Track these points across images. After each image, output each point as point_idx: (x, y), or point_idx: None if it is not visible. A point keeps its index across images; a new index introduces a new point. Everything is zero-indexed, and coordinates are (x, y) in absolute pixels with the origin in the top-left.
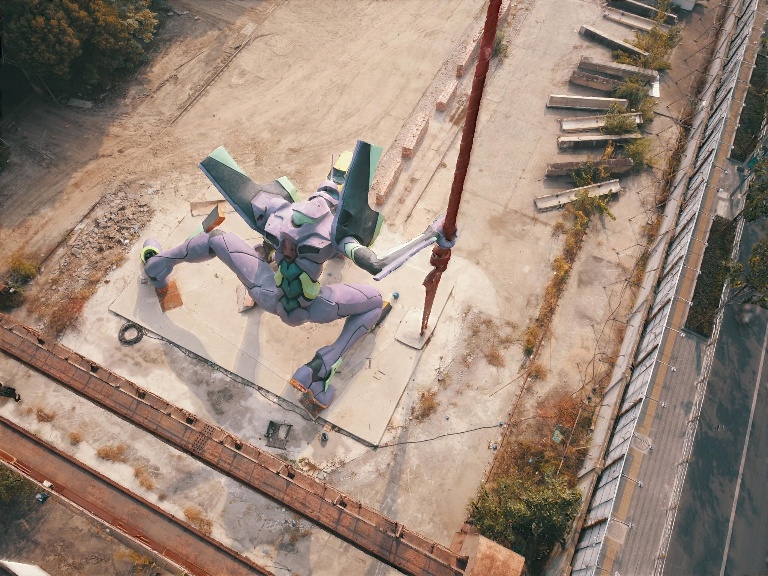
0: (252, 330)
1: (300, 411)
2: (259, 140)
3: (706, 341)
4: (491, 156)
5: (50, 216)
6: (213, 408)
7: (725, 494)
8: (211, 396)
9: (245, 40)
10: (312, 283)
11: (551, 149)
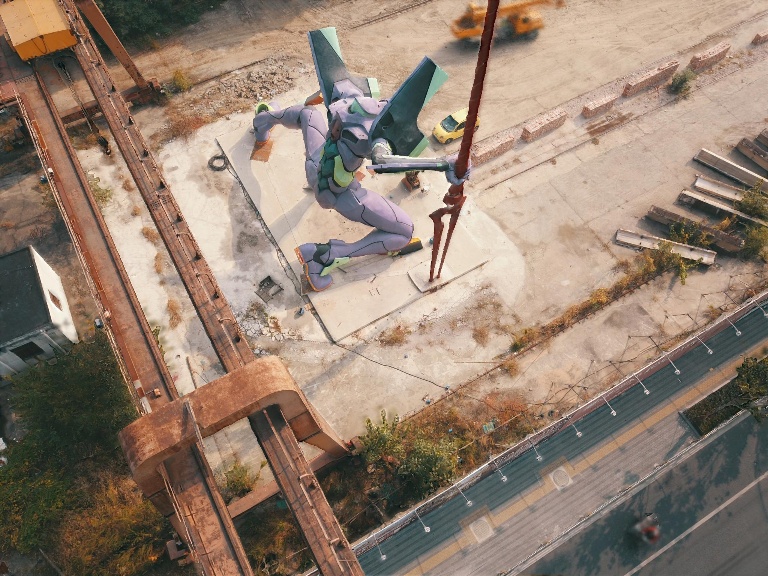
0: (303, 206)
1: (297, 283)
2: (410, 71)
3: (697, 437)
4: (604, 175)
5: (222, 55)
6: (237, 245)
7: (610, 571)
8: (242, 236)
9: None
10: (344, 170)
11: (669, 197)
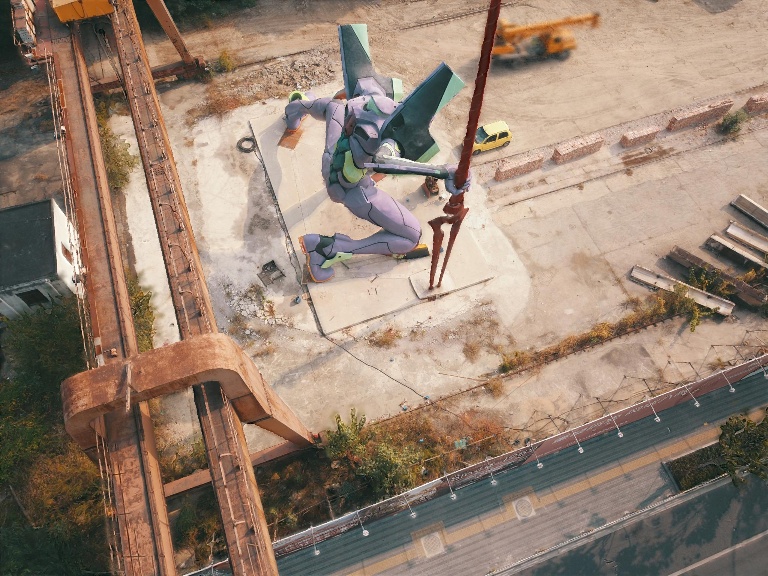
0: (320, 197)
1: (299, 271)
2: None
3: (676, 491)
4: (631, 208)
5: (271, 41)
6: (250, 226)
7: None
8: (256, 218)
9: (512, 1)
10: (354, 166)
11: (696, 239)
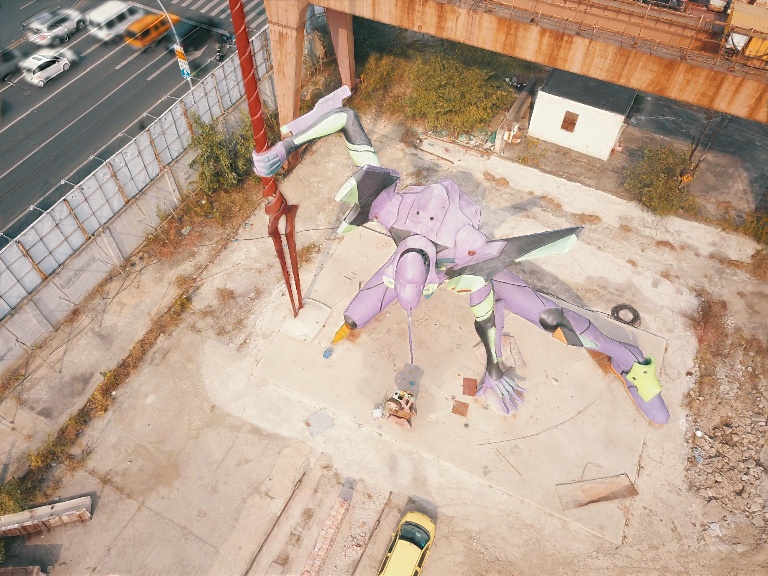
0: None
1: None
2: None
3: None
4: None
5: None
6: None
7: (62, 190)
8: None
9: None
10: None
11: None
